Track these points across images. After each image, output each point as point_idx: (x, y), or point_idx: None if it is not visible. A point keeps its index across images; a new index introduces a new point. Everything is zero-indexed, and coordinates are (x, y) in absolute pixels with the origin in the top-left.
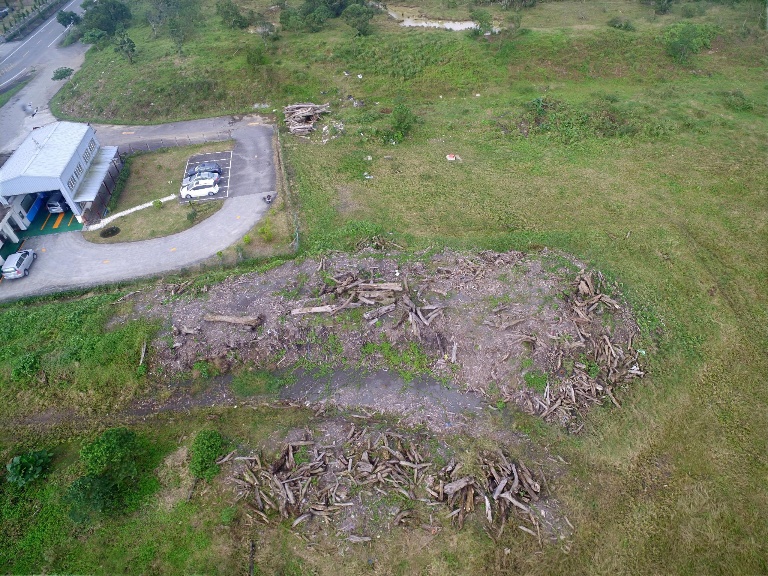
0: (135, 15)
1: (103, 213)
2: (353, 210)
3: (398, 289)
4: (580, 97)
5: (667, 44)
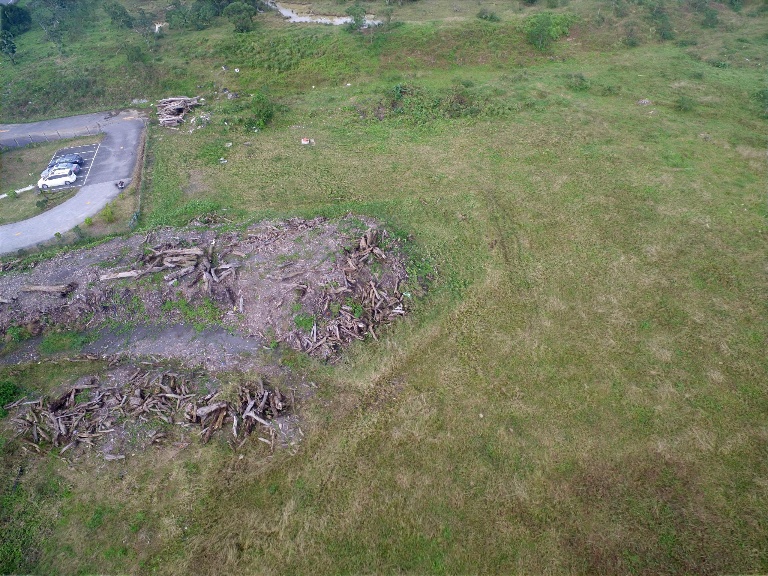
0: (35, 18)
1: None
2: (200, 191)
3: (200, 253)
4: (441, 83)
5: (528, 33)
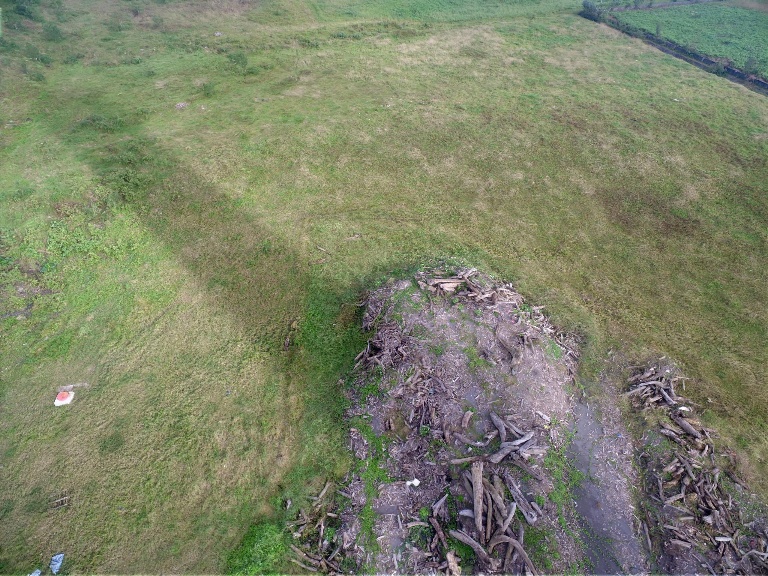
0: None
1: None
2: None
3: None
4: None
5: None
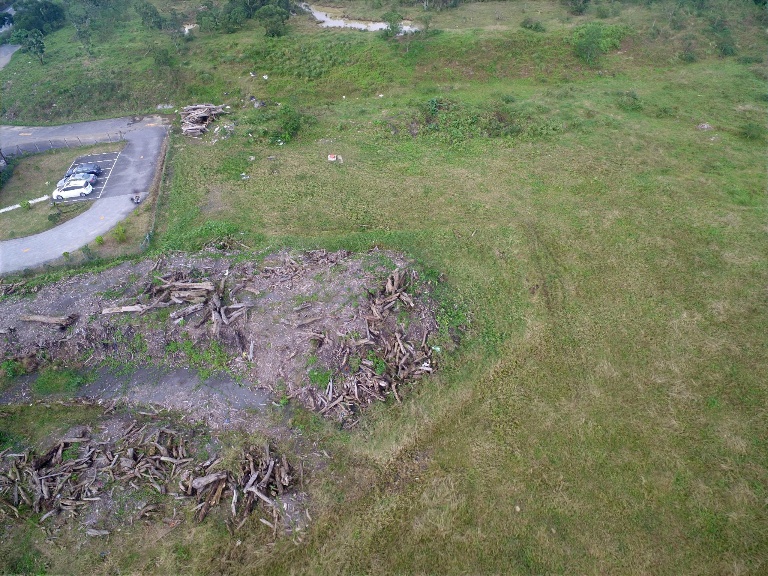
0: None
1: None
2: (218, 210)
3: (210, 288)
4: (480, 97)
5: (575, 45)
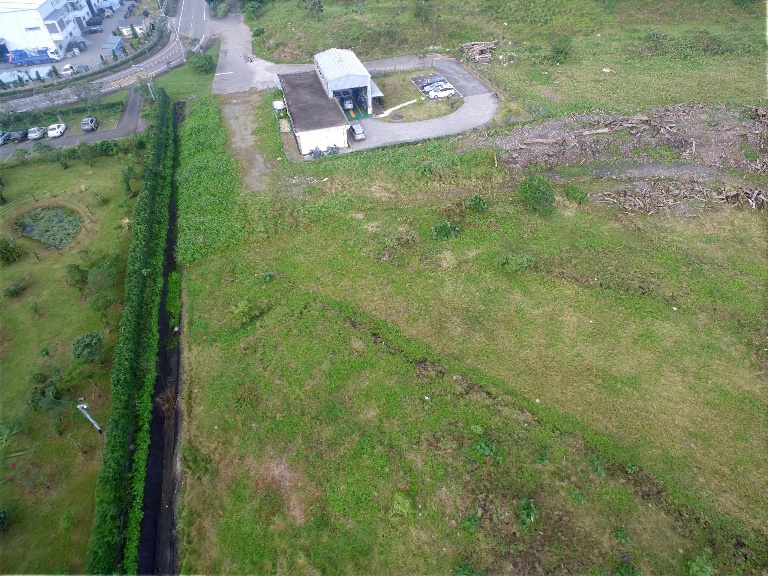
0: None
1: (381, 108)
2: (560, 99)
3: (646, 118)
4: (678, 33)
5: None
